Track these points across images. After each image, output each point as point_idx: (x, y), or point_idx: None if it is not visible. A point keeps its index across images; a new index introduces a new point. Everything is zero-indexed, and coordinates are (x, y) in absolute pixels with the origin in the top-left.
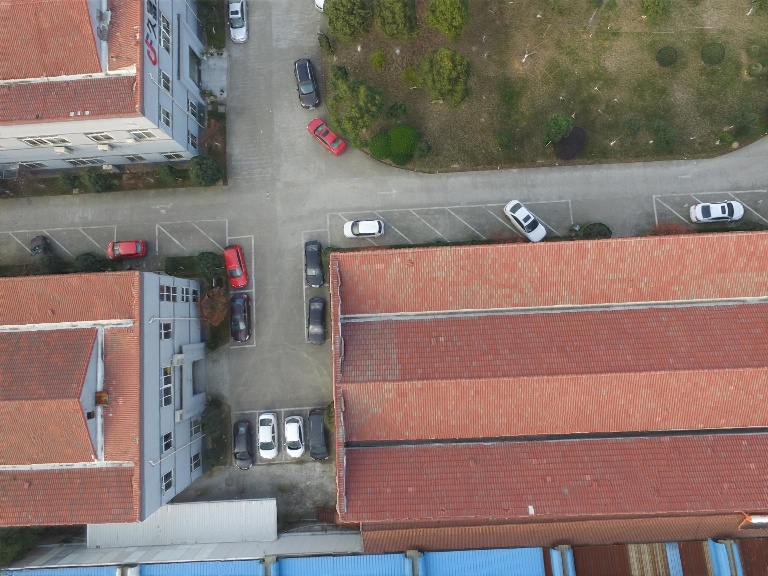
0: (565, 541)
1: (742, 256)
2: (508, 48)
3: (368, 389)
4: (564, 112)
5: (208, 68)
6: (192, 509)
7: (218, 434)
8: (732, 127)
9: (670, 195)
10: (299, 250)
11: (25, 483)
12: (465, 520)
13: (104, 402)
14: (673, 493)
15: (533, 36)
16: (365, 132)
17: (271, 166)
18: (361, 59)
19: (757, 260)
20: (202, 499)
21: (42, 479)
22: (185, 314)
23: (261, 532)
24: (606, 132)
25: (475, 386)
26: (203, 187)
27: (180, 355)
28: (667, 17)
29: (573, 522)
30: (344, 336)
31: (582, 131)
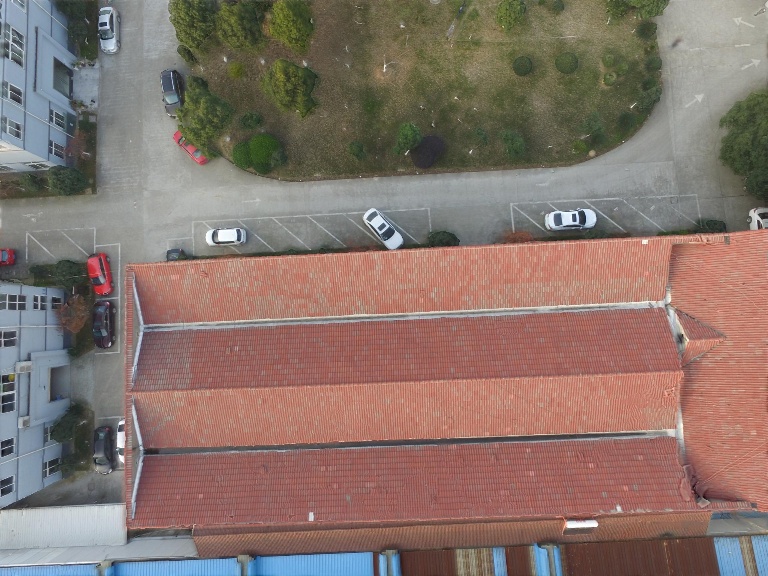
0: (393, 546)
1: (526, 267)
2: (371, 58)
3: (159, 398)
4: (425, 121)
5: (80, 79)
6: (46, 513)
7: (81, 439)
8: (589, 135)
9: (527, 203)
10: (164, 258)
11: None
12: (294, 525)
13: None
14: (448, 500)
15: (396, 46)
16: (229, 141)
17: (139, 175)
18: (228, 69)
19: (542, 271)
20: (58, 504)
21: None
22: (39, 322)
23: (114, 536)
24: (465, 141)
25: (262, 395)
26: (73, 196)
27: (25, 362)
28: (527, 27)
29: (398, 527)
30: (143, 345)
31: (438, 140)
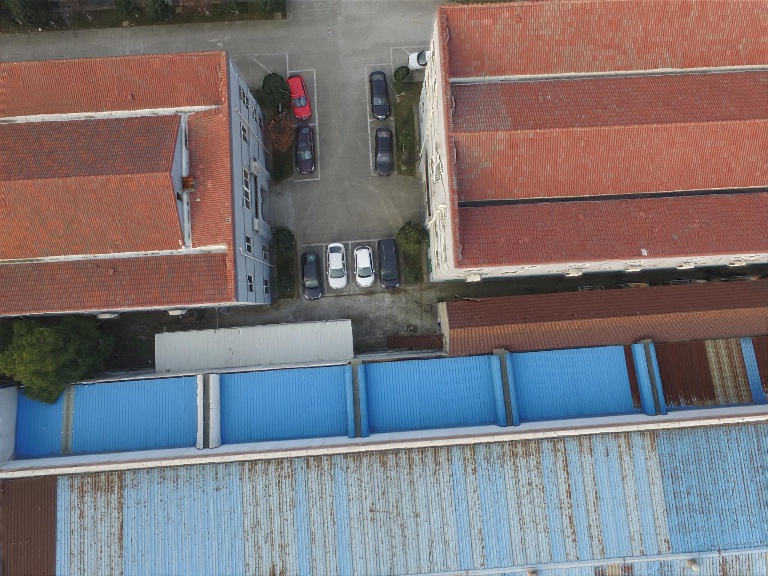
0: (646, 337)
1: None
2: None
3: (480, 140)
4: None
5: None
6: (265, 331)
7: (284, 266)
8: None
9: None
10: (362, 84)
11: (109, 270)
12: (551, 316)
13: (191, 187)
14: None
15: None
16: None
17: None
18: None
19: None
20: None
21: (127, 266)
22: (255, 132)
23: (336, 354)
24: None
25: (586, 136)
26: (261, 21)
27: (256, 163)
28: None
29: (655, 315)
30: None
31: None
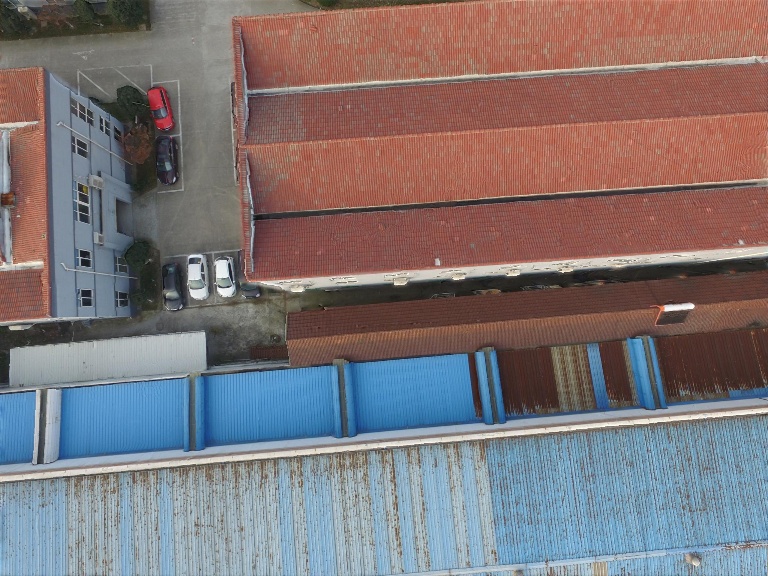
0: (489, 345)
1: (640, 17)
2: None
3: (273, 152)
4: None
5: None
6: (119, 344)
7: (147, 278)
8: None
9: None
10: (226, 94)
11: None
12: (389, 325)
13: (11, 203)
14: (574, 240)
15: None
16: None
17: (196, 10)
18: None
19: (654, 22)
20: (130, 336)
21: None
22: (105, 145)
23: (191, 366)
24: None
25: (380, 145)
26: (126, 33)
27: (97, 177)
28: None
29: (495, 322)
30: (250, 107)
31: None
